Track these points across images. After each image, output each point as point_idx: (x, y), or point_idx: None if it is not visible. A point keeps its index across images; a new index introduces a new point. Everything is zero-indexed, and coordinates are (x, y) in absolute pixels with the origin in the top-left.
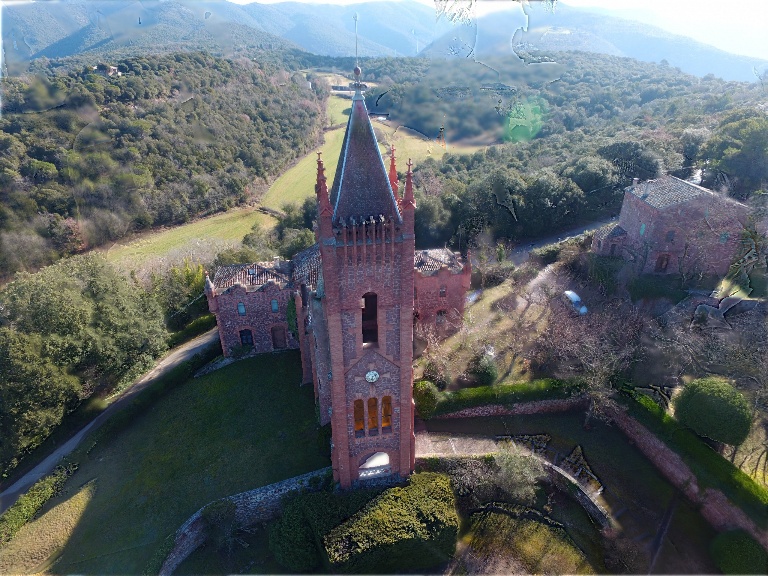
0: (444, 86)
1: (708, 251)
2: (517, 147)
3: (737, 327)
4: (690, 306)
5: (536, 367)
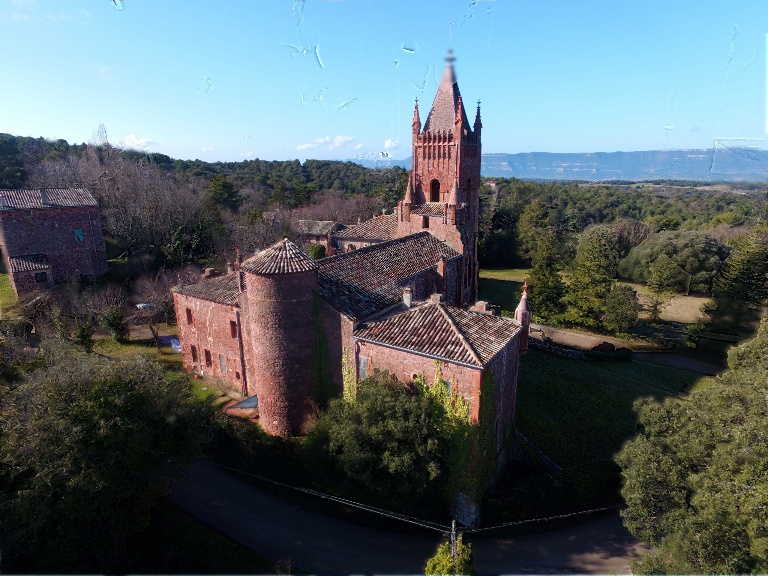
0: None
1: (163, 216)
2: (45, 147)
3: None
4: (288, 207)
5: None
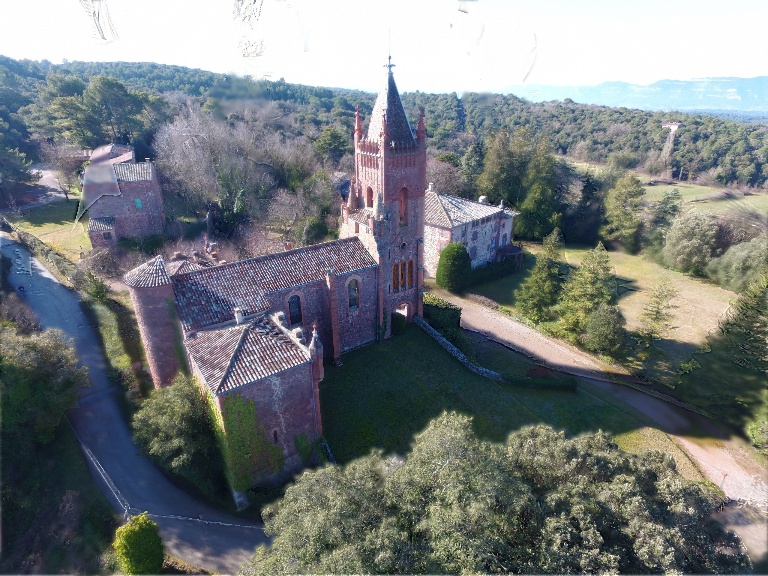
0: (246, 74)
1: None
2: (69, 153)
3: None
4: (302, 186)
5: None
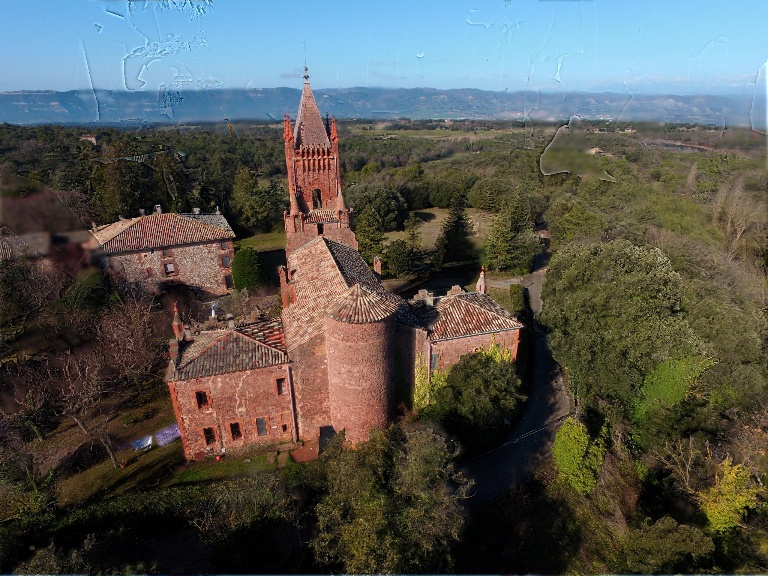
0: (216, 78)
1: None
2: None
3: (4, 286)
4: None
5: (154, 364)
